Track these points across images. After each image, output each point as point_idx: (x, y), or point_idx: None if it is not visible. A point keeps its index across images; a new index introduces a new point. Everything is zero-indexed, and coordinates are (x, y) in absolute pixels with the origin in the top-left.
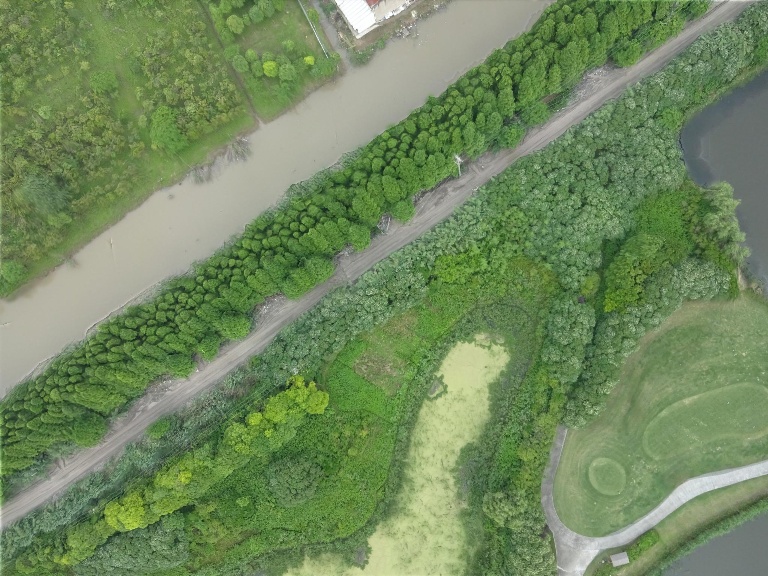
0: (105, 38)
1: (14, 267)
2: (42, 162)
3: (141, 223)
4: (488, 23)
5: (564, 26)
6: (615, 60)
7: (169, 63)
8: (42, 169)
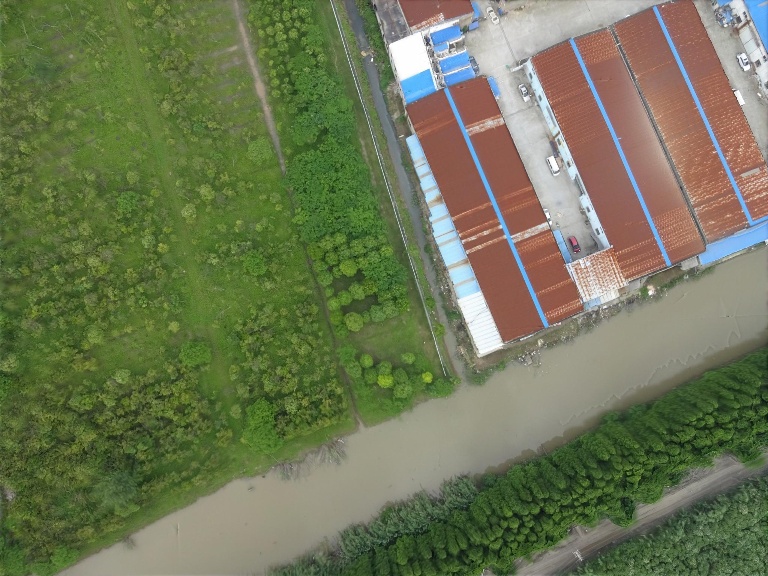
0: (199, 292)
1: (66, 552)
2: (111, 432)
3: (214, 513)
4: (611, 366)
5: (705, 440)
6: (734, 454)
7: (271, 343)
8: (111, 443)
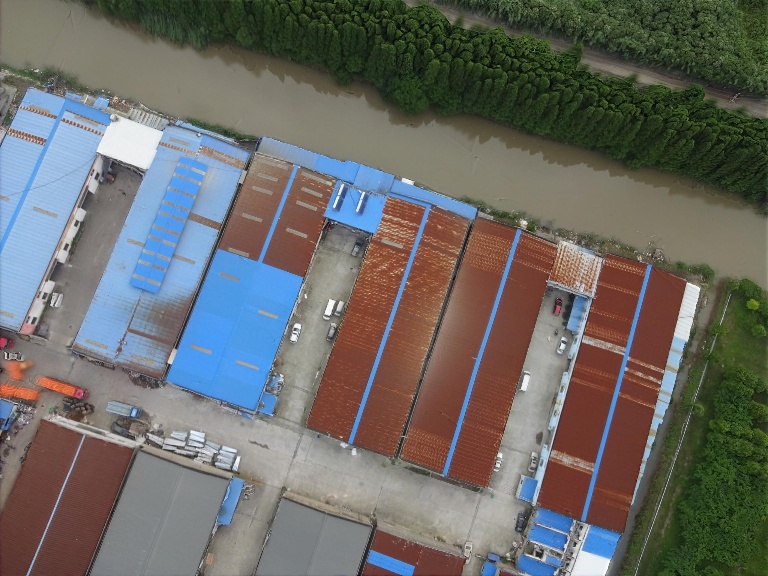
0: None
1: None
2: None
3: None
4: (596, 197)
5: (622, 94)
6: None
7: None
8: None
